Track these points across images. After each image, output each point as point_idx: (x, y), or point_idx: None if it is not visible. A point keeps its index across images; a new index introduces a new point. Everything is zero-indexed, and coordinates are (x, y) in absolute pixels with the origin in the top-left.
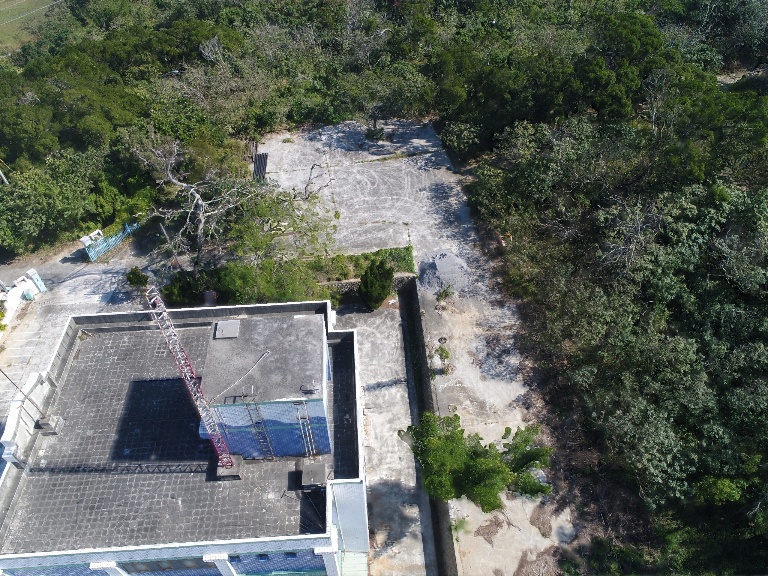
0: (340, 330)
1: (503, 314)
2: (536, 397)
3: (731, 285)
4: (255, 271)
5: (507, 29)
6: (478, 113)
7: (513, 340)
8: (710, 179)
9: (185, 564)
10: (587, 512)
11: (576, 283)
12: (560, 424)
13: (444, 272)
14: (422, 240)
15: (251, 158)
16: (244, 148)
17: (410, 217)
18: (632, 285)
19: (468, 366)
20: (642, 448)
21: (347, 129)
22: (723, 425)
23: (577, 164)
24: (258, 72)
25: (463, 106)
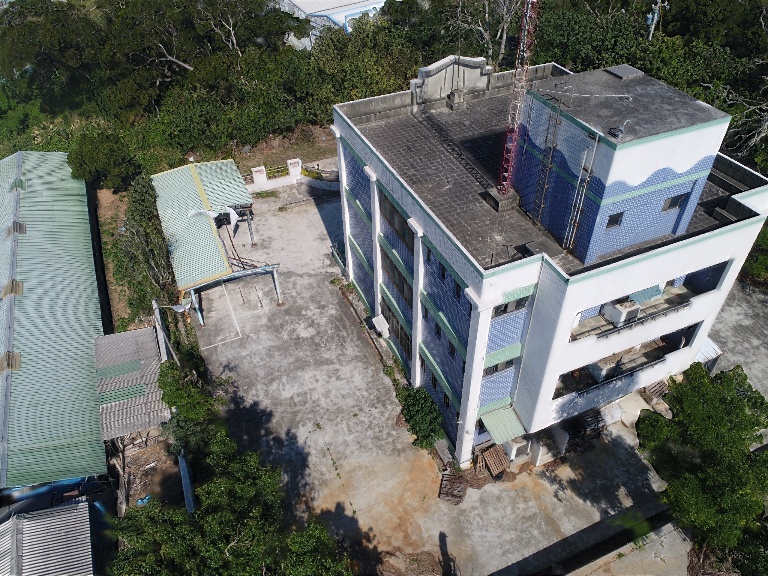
0: (747, 204)
1: None
2: None
3: None
4: None
5: None
6: None
7: None
8: None
9: (405, 235)
10: None
11: None
12: None
13: None
14: None
15: None
16: None
17: None
18: None
19: None
20: None
21: None
22: None
23: None
24: None
25: None
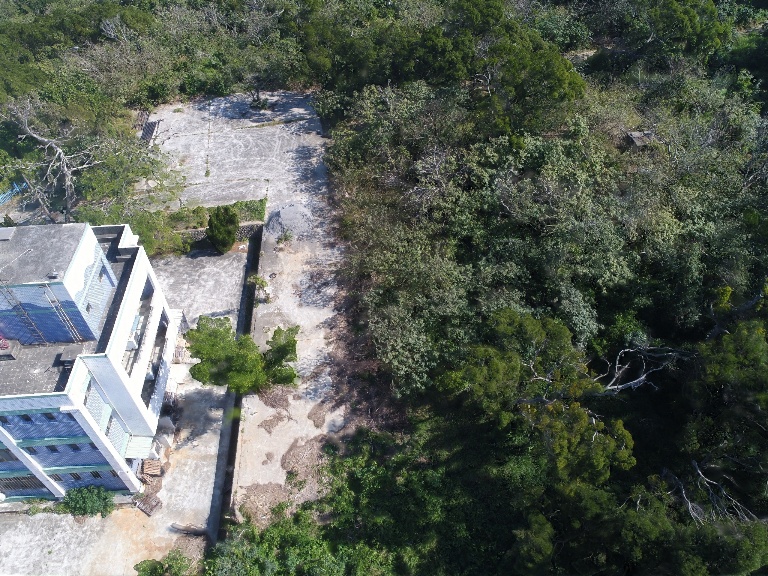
0: (128, 246)
1: (332, 253)
2: (341, 320)
3: (525, 223)
4: (104, 214)
5: (403, 10)
6: (347, 82)
7: (334, 274)
8: (517, 132)
9: None
10: (359, 408)
11: (381, 220)
12: (355, 340)
13: (286, 219)
14: (278, 194)
15: (141, 126)
16: (136, 117)
17: (272, 175)
18: (434, 223)
19: (289, 296)
20: (389, 346)
21: (235, 100)
22: (479, 333)
23: (411, 122)
24: (160, 49)
25: (334, 76)
